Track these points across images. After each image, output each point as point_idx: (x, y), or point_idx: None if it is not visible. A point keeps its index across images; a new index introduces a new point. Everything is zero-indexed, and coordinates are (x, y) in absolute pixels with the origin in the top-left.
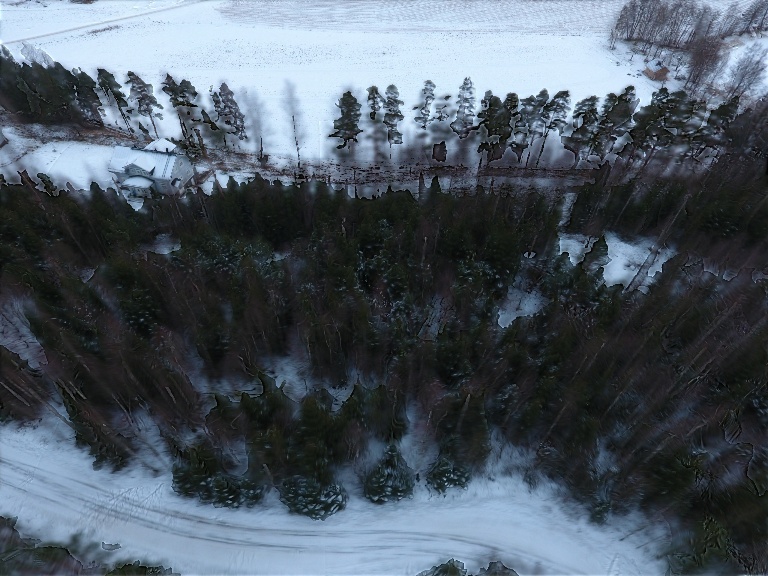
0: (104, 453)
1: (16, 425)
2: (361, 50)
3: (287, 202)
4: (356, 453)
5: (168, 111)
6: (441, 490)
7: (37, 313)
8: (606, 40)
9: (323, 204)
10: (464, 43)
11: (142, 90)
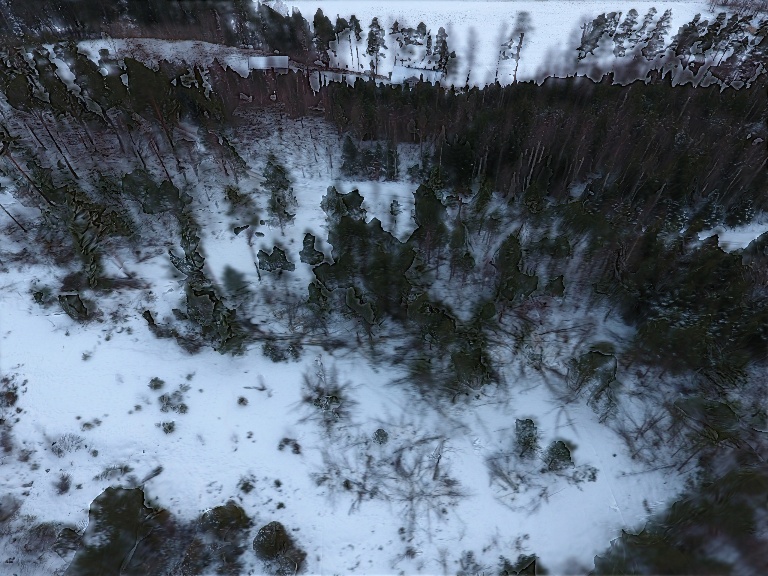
0: (542, 197)
1: (463, 196)
2: (492, 14)
3: (569, 87)
4: (704, 187)
5: (362, 59)
6: (740, 220)
7: (476, 129)
8: (704, 5)
9: (597, 87)
10: (579, 8)
11: (376, 33)
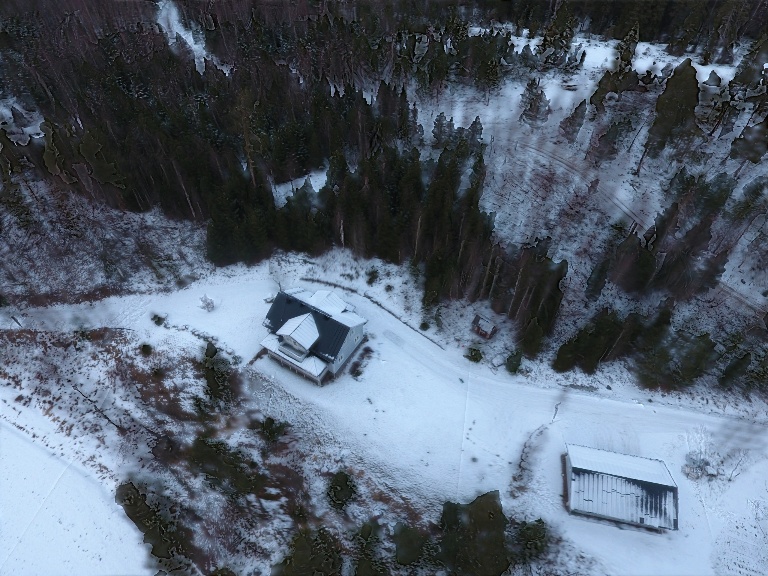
0: None
1: None
2: None
3: None
4: None
5: None
6: None
7: None
8: None
9: None
10: None
11: None
